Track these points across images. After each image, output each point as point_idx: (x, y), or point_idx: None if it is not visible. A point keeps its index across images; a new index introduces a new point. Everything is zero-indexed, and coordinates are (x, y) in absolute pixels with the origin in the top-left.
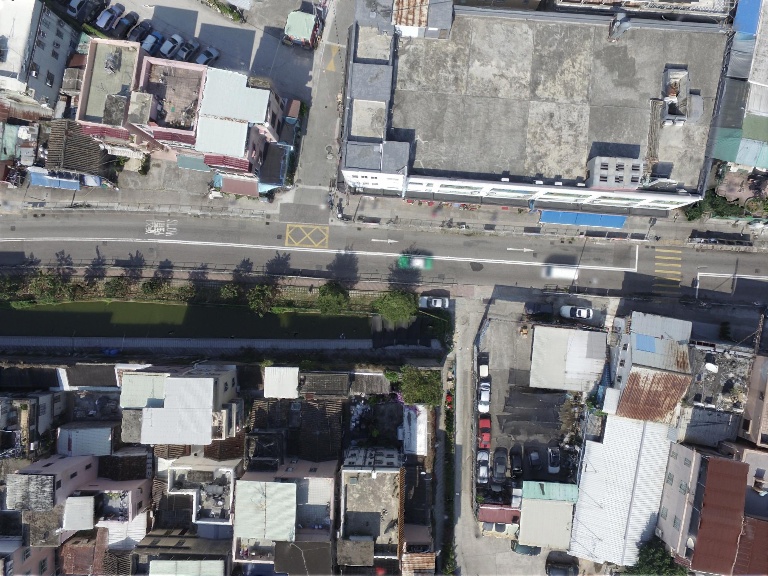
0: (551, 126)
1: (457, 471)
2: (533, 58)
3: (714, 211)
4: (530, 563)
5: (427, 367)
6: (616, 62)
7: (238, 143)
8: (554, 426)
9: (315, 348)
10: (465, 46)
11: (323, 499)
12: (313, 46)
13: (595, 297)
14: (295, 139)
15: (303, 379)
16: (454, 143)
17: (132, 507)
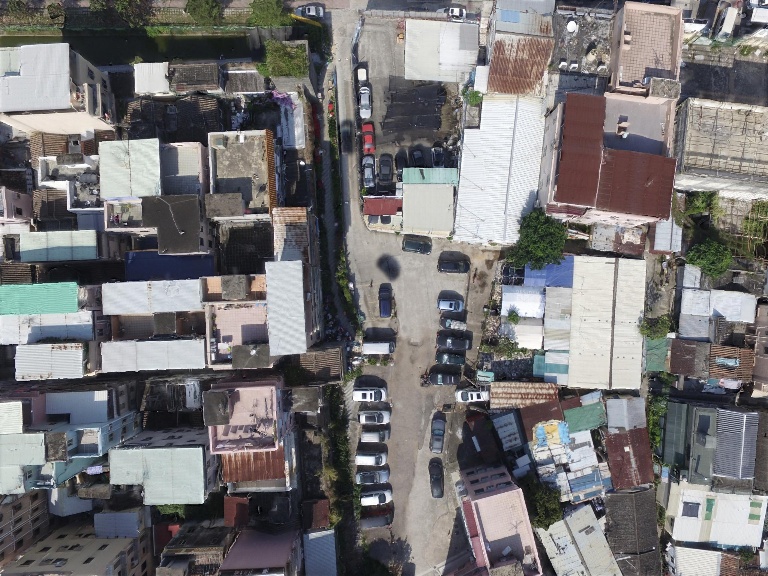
0: None
1: (344, 180)
2: None
3: None
4: (422, 265)
5: (291, 41)
6: None
7: None
8: (436, 126)
9: None
10: None
11: (194, 170)
12: None
13: (469, 1)
14: None
15: (172, 71)
16: None
17: (6, 203)
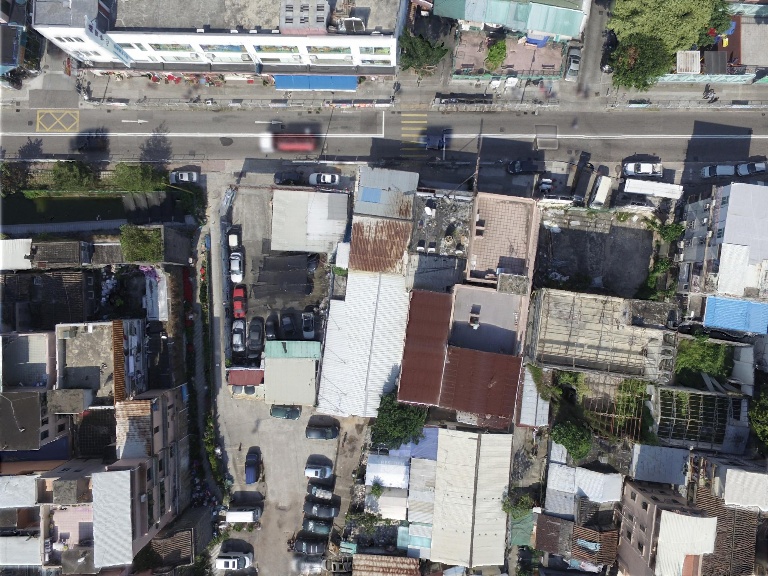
0: None
1: (216, 343)
2: None
3: (454, 72)
4: (292, 428)
5: None
6: None
7: None
8: (306, 291)
9: (71, 231)
10: None
11: (44, 357)
12: None
13: (344, 164)
14: None
15: (34, 249)
16: (154, 0)
17: None
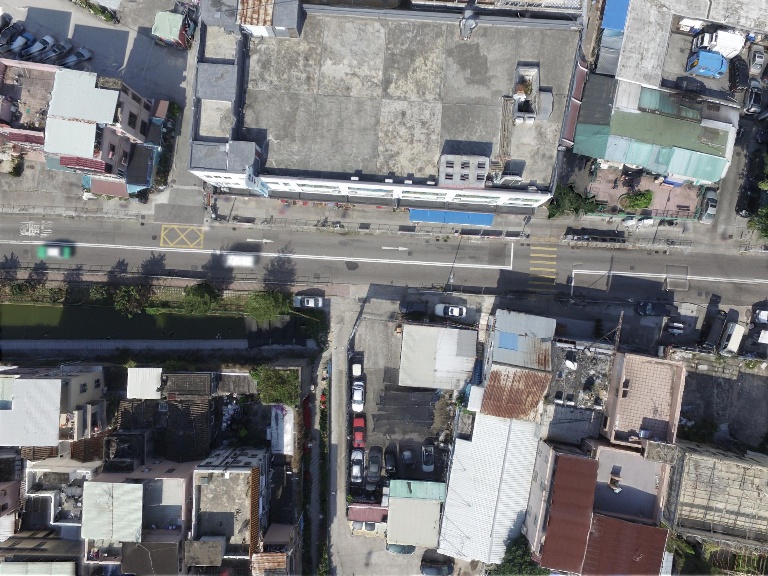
0: (403, 124)
1: (333, 470)
2: (385, 56)
3: None
4: (406, 562)
5: (284, 367)
6: (468, 60)
7: (87, 144)
8: (428, 424)
9: (191, 348)
10: (317, 45)
11: (177, 499)
12: (186, 46)
13: (470, 295)
14: (169, 139)
15: (165, 380)
16: (306, 142)
17: None
